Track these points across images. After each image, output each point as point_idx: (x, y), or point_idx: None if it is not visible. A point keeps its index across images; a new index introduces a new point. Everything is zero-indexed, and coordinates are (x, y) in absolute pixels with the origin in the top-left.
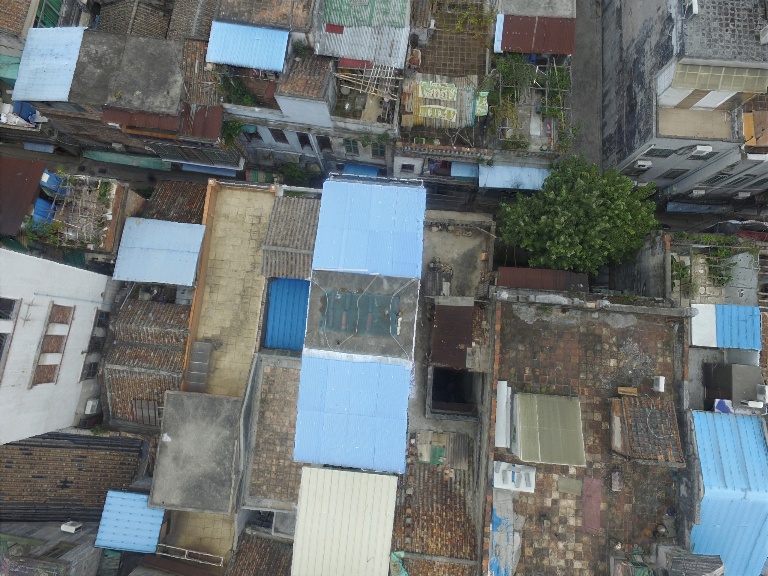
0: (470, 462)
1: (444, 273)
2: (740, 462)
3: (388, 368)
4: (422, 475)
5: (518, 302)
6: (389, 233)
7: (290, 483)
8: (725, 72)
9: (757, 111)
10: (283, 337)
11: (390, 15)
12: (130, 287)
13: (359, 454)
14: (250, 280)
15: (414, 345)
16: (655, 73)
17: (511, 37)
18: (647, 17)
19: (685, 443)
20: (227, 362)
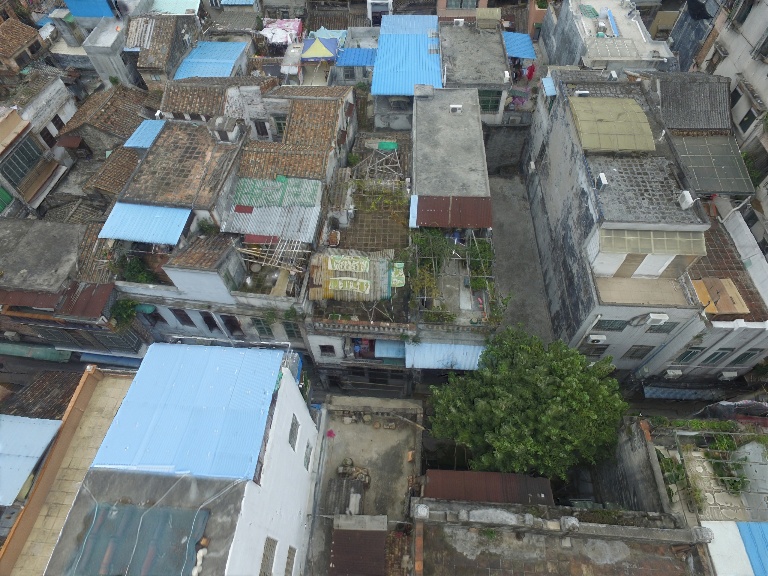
0: None
1: (354, 480)
2: None
3: None
4: None
5: (448, 522)
6: (221, 410)
7: None
8: (654, 236)
9: (706, 278)
10: None
11: (301, 196)
12: None
13: None
14: None
15: None
16: (583, 243)
17: (426, 214)
18: (565, 197)
19: None
20: None
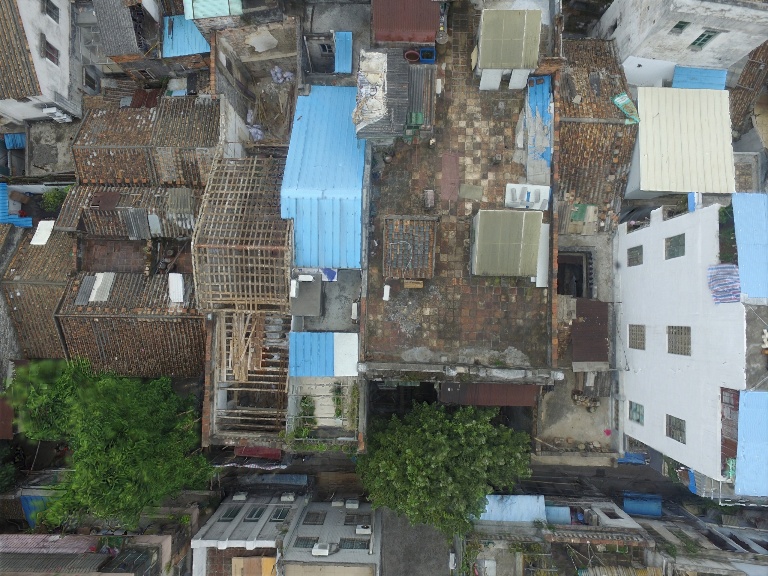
0: None
1: None
2: (322, 223)
3: (765, 294)
4: (596, 193)
5: None
6: None
7: None
8: None
9: None
10: None
11: None
12: None
13: None
14: None
15: (743, 320)
16: None
17: None
18: None
19: None
20: None
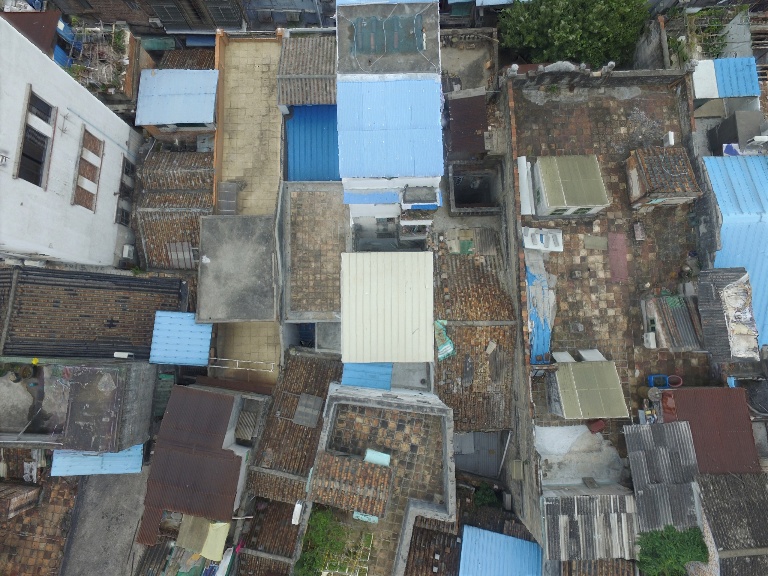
0: (498, 249)
1: (453, 78)
2: (752, 192)
3: (418, 84)
4: (454, 263)
5: (528, 80)
6: None
7: (328, 295)
8: None
9: None
10: (305, 171)
11: None
12: (151, 143)
13: (400, 164)
14: (266, 123)
15: None
16: None
17: None
18: None
19: (699, 185)
20: (253, 200)
